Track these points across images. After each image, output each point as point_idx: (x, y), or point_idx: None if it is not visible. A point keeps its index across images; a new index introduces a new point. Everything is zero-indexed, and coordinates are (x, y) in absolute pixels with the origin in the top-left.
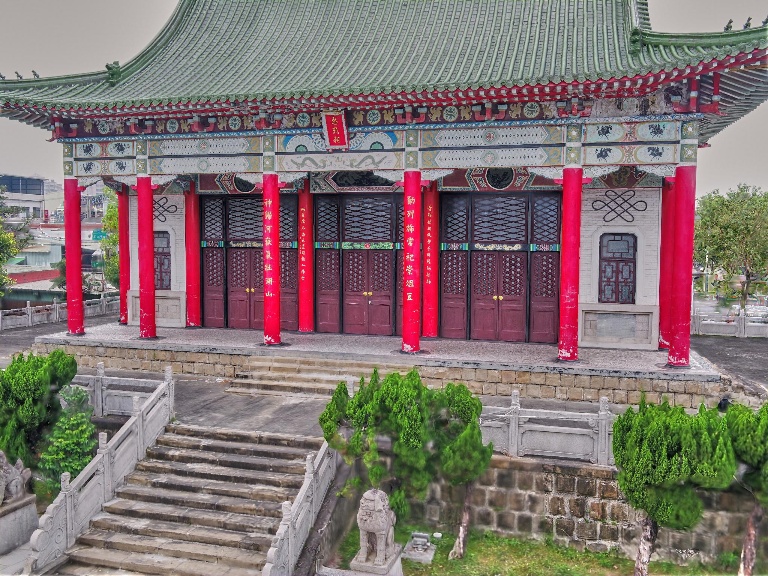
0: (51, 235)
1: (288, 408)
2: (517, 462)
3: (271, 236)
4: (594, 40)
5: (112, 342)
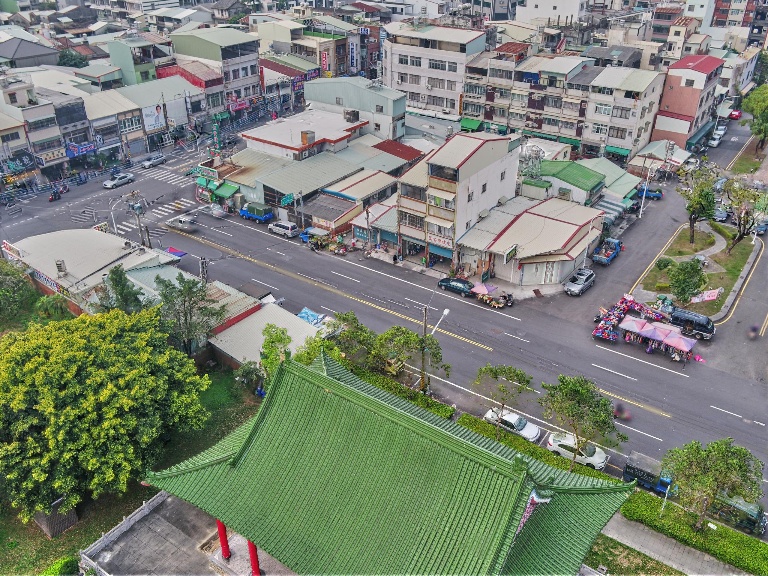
0: (259, 147)
1: None
2: None
3: None
4: (463, 575)
5: None
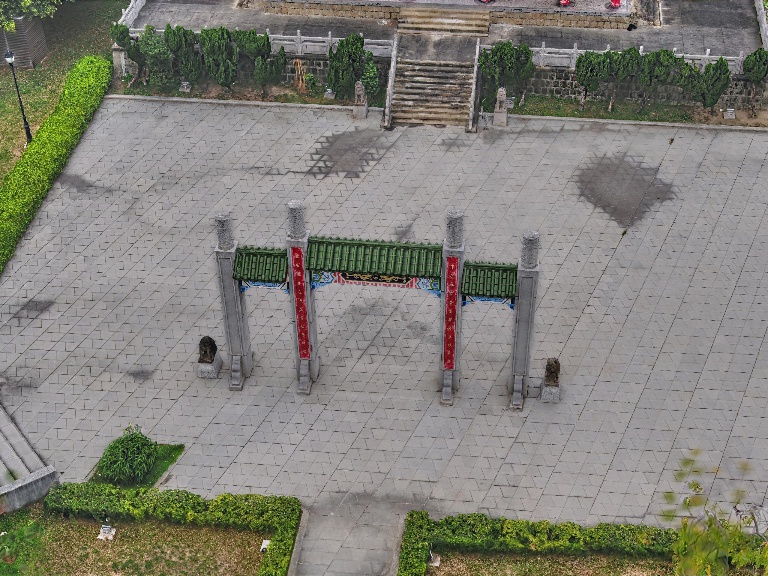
0: None
1: (438, 44)
2: (543, 69)
3: None
4: None
5: (315, 0)
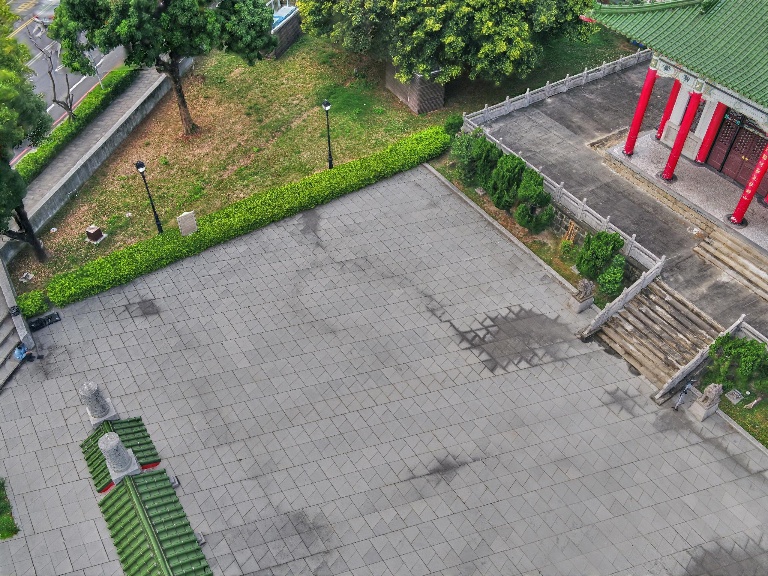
0: None
1: (718, 286)
2: None
3: (761, 169)
4: None
5: (646, 176)
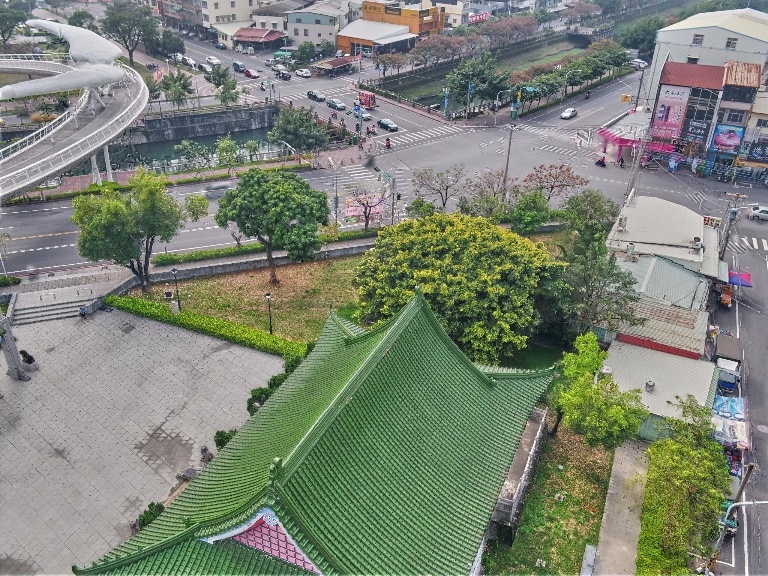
0: None
1: None
2: None
3: None
4: None
5: None
